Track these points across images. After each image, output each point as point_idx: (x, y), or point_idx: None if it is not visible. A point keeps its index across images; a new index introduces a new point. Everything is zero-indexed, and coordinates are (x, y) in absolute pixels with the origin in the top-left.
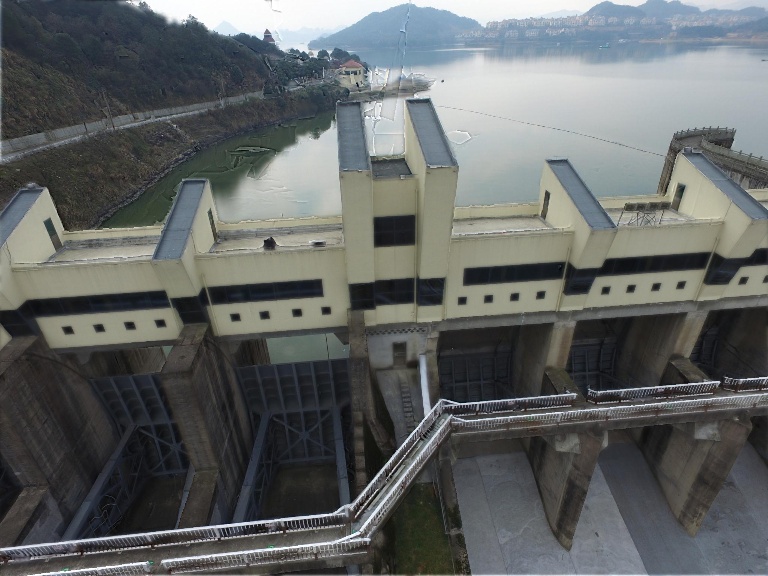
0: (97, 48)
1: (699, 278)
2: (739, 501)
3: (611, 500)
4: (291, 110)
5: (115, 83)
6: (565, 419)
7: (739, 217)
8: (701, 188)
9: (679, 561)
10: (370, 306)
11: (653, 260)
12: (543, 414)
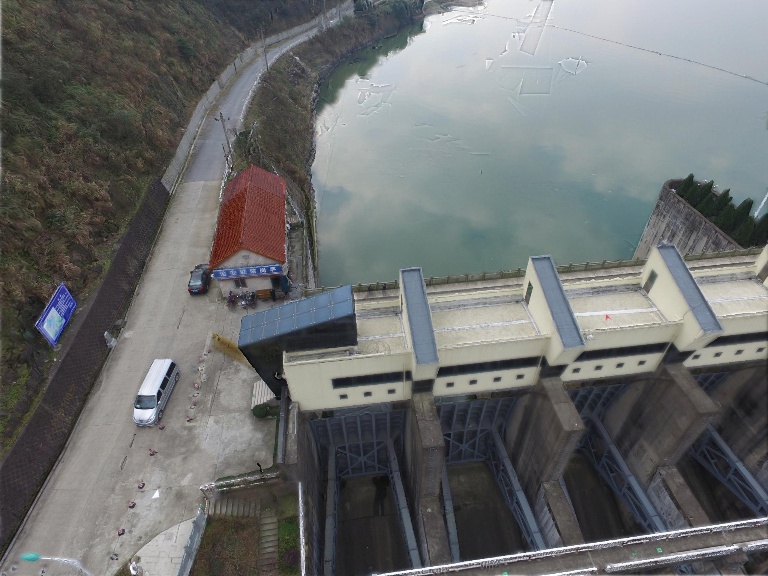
0: None
1: None
2: None
3: None
4: (378, 28)
5: (230, 8)
6: None
7: None
8: None
9: None
10: None
11: None
12: None
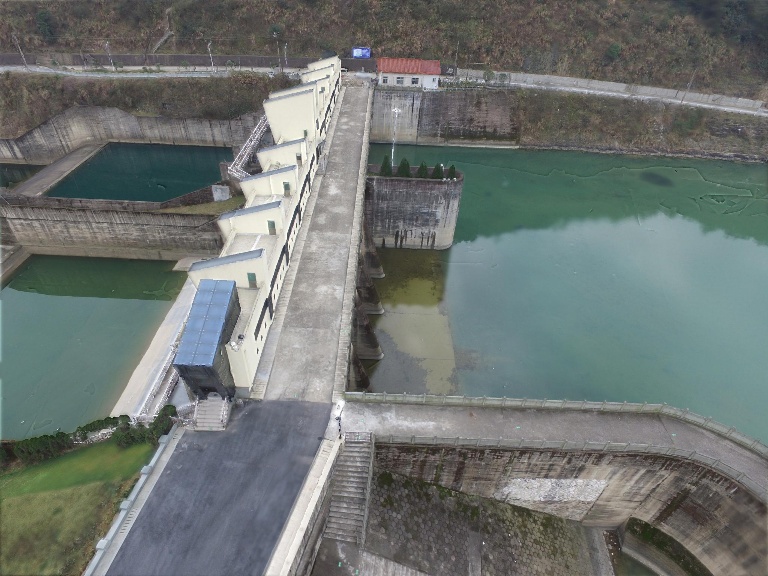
0: None
1: None
2: None
3: None
4: None
5: None
6: None
7: None
8: None
9: None
10: None
11: None
12: None
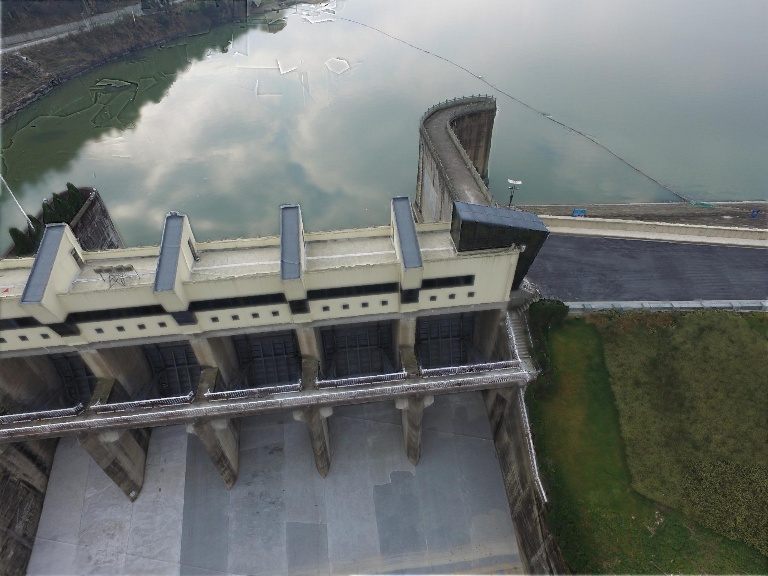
0: None
1: (174, 320)
2: (279, 462)
3: (183, 464)
4: (177, 27)
5: None
6: (54, 429)
7: None
8: None
9: (210, 507)
10: None
11: (126, 310)
12: (32, 427)
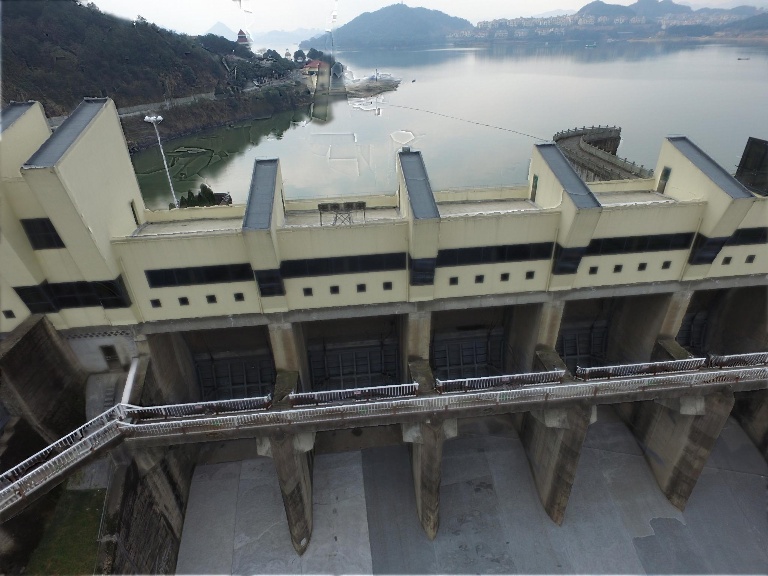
0: (33, 49)
1: (404, 279)
2: (491, 504)
3: (362, 503)
4: (244, 111)
5: (51, 84)
6: (243, 423)
7: (410, 217)
8: (402, 188)
9: (409, 565)
10: (51, 309)
11: (349, 261)
12: (216, 418)
